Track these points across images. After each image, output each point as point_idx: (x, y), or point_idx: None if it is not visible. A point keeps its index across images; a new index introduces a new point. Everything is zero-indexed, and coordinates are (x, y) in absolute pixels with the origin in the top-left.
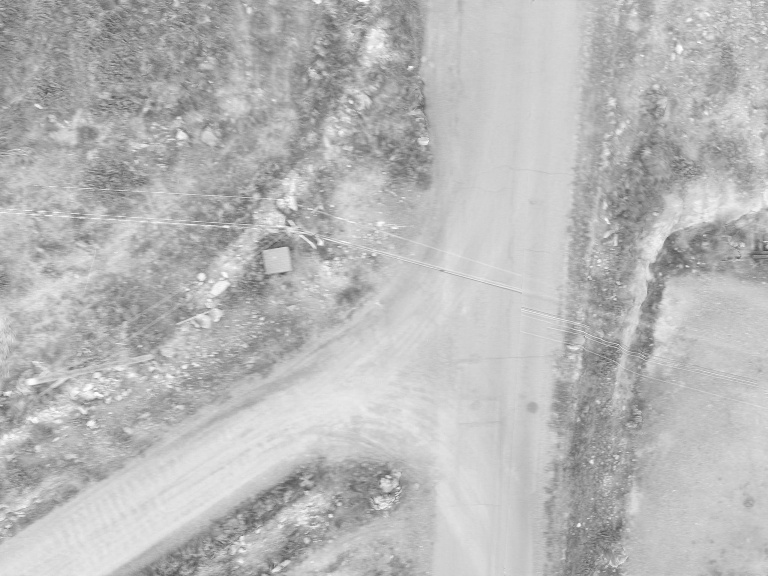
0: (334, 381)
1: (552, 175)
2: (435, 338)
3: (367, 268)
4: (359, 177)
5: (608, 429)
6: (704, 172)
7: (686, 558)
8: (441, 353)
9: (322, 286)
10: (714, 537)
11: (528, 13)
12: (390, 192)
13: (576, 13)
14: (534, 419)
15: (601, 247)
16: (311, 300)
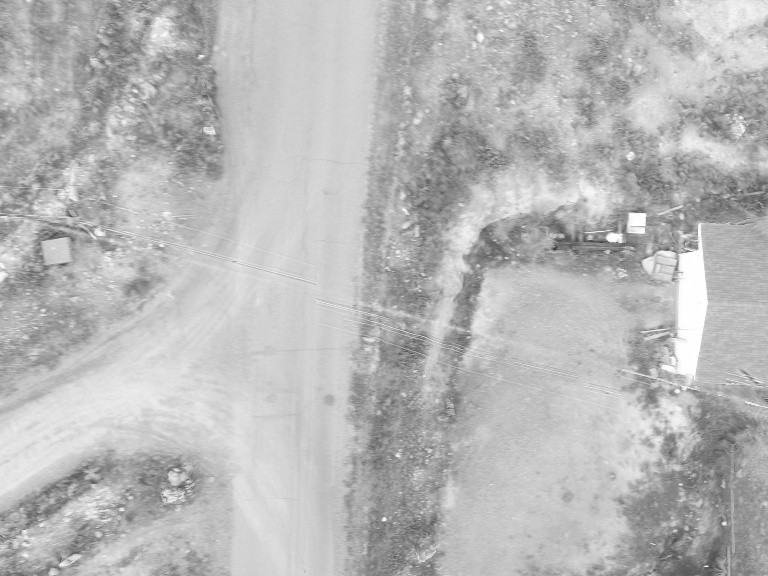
0: (123, 373)
1: (347, 165)
2: (228, 330)
3: (155, 259)
4: (144, 167)
5: (417, 422)
6: (512, 162)
7: (503, 553)
8: (234, 345)
9: (106, 277)
10: (532, 532)
11: (322, 1)
12: (177, 182)
13: (372, 1)
14: (331, 412)
15: (399, 238)
16: (96, 291)
